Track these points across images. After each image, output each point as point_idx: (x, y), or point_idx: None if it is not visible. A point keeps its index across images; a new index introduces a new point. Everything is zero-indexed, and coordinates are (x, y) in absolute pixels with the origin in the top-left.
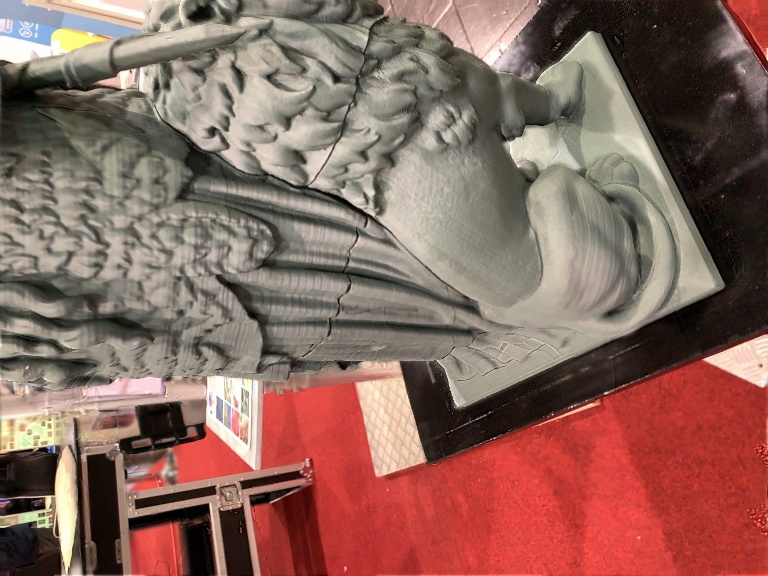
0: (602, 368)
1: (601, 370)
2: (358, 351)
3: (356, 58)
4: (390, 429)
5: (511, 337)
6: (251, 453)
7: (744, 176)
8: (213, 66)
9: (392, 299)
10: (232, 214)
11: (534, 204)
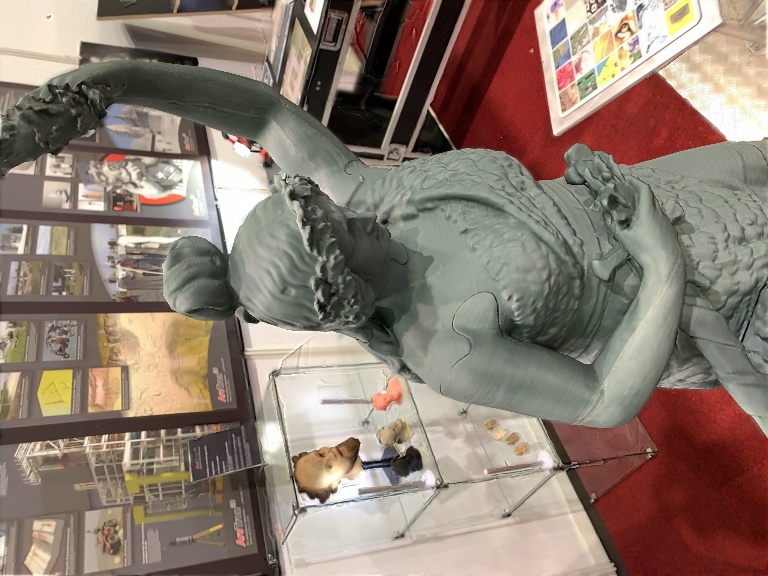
0: None
1: None
2: None
3: None
4: None
5: None
6: (560, 122)
7: None
8: None
9: None
10: None
11: None
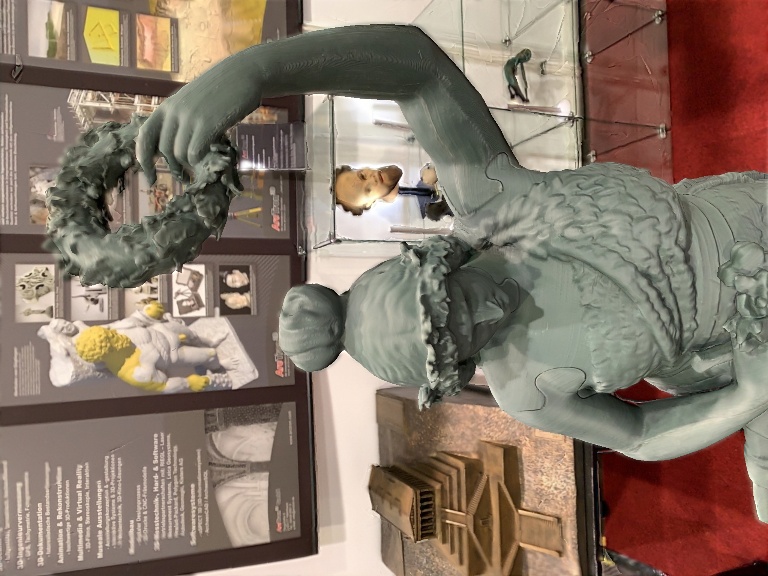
0: None
1: None
2: None
3: None
4: None
5: None
6: None
7: None
8: None
9: None
10: None
11: None
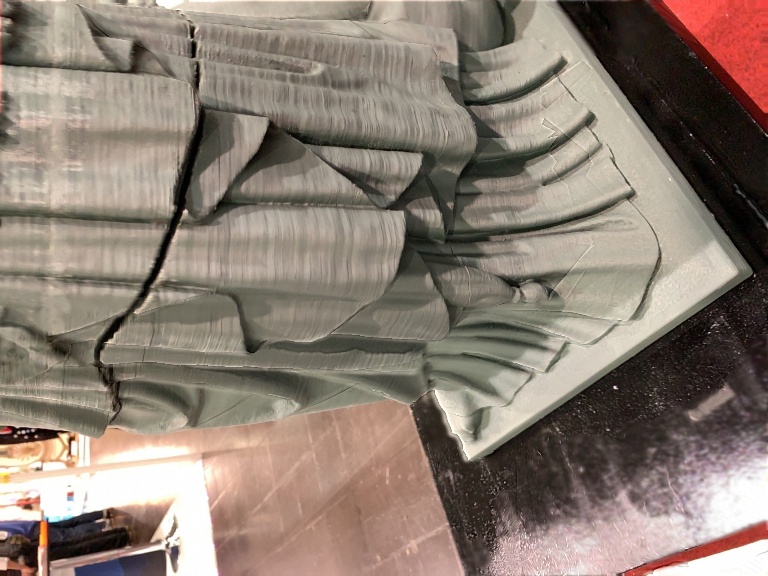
0: (597, 4)
1: (600, 3)
2: (288, 74)
3: None
4: None
5: (523, 101)
6: None
7: None
8: None
9: (250, 19)
10: None
11: None
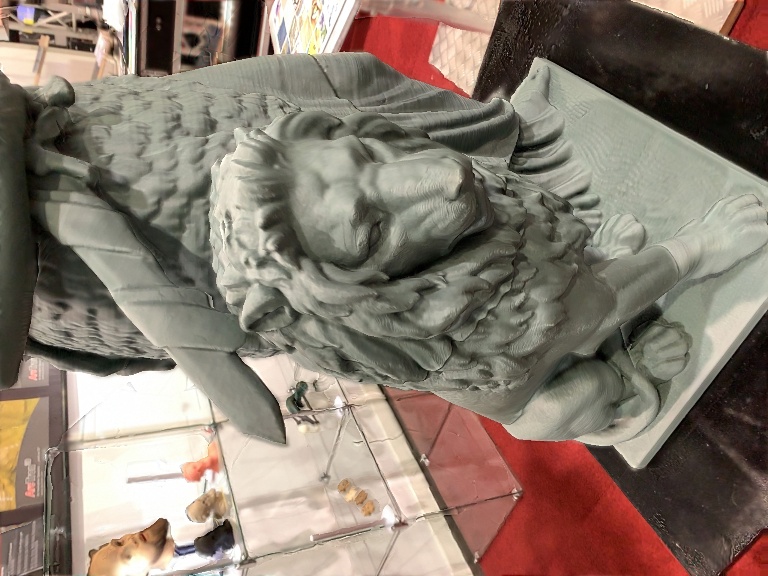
0: None
1: None
2: None
3: (415, 381)
4: (463, 37)
5: None
6: None
7: (730, 460)
8: (268, 334)
9: None
10: (262, 347)
11: (538, 404)
